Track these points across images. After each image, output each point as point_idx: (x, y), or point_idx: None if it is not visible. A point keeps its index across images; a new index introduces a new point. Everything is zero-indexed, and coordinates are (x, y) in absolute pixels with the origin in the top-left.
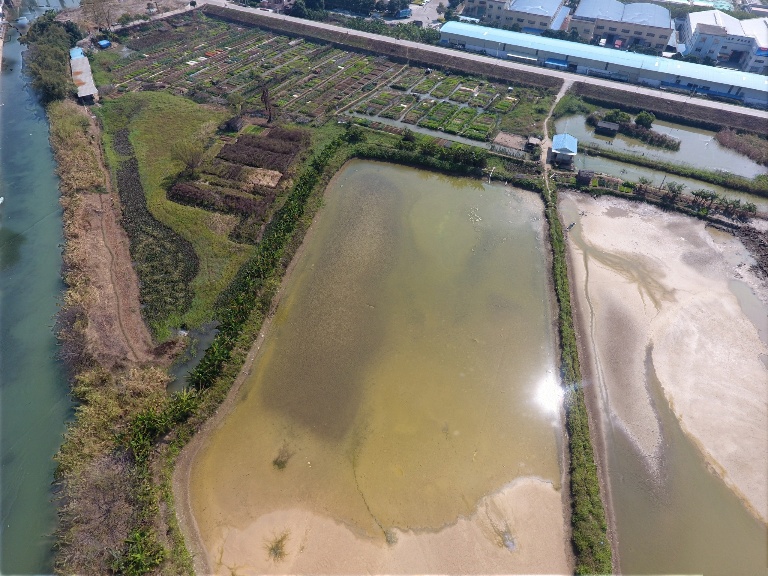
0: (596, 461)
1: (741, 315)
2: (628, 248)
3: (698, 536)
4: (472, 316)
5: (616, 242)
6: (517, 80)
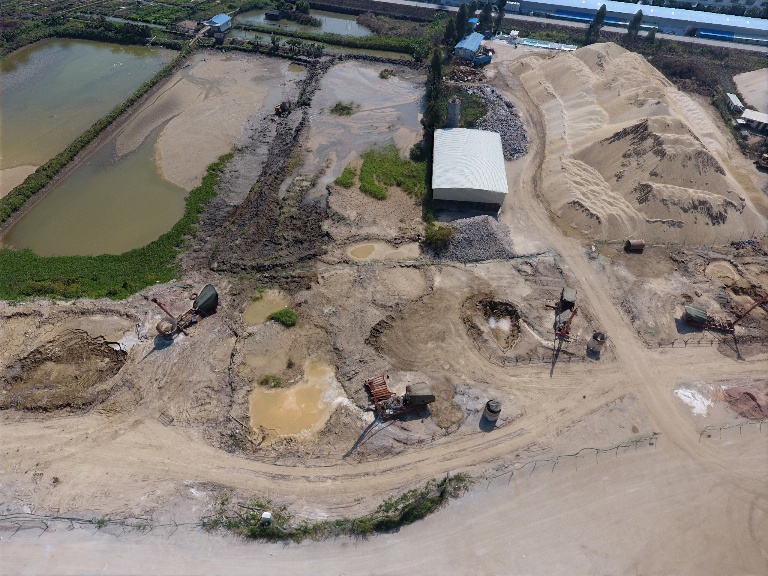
0: (79, 157)
1: (259, 101)
2: (218, 75)
3: None
4: (63, 107)
5: (212, 72)
6: None
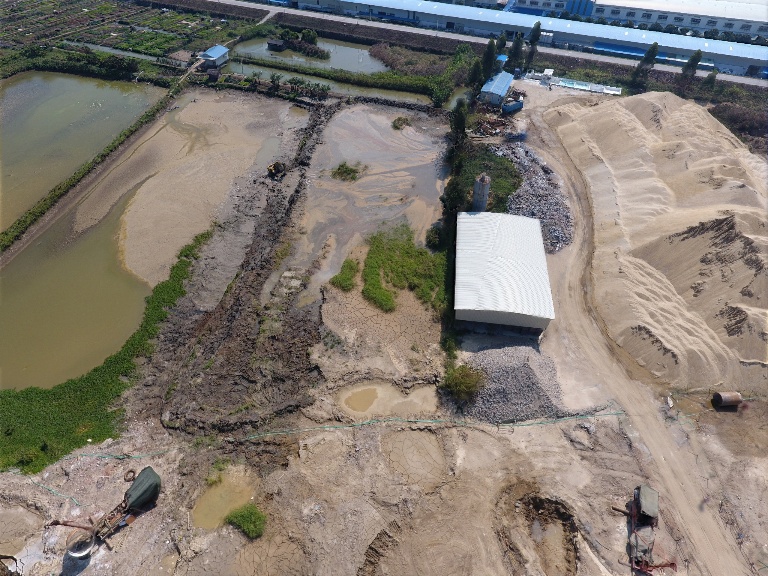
0: (28, 235)
1: (251, 156)
2: (207, 120)
3: (63, 270)
4: (24, 162)
5: (202, 117)
6: (233, 14)
